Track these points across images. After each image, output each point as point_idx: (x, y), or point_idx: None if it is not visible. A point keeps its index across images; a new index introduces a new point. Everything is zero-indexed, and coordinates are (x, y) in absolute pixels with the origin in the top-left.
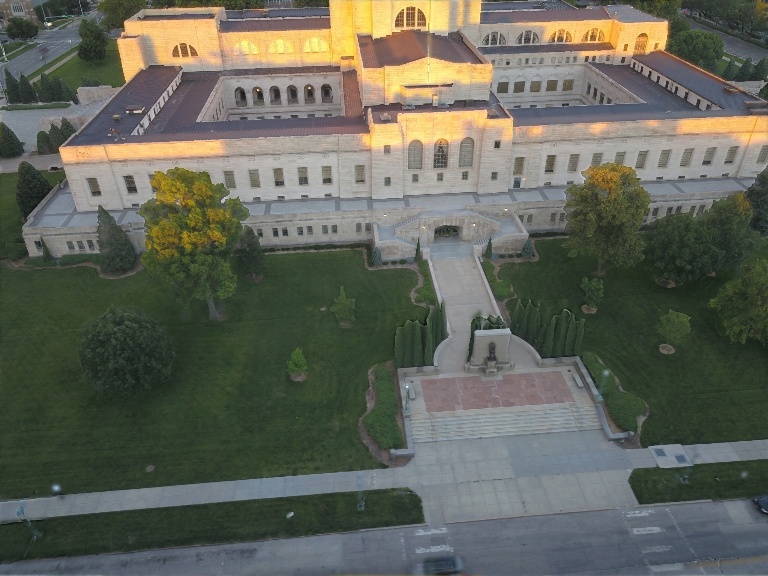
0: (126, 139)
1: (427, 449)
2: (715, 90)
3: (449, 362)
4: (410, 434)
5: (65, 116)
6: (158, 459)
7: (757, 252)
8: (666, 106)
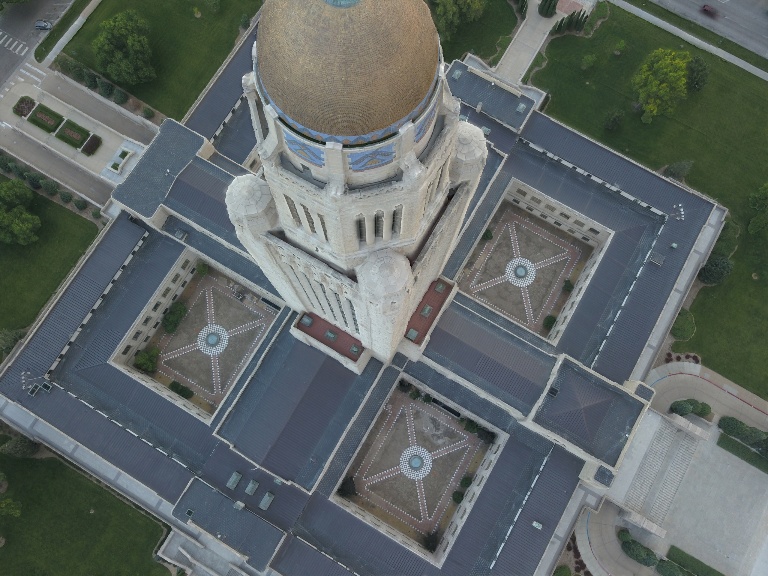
0: (673, 205)
1: None
2: None
3: None
4: None
5: (688, 426)
6: (679, 47)
7: None
8: None
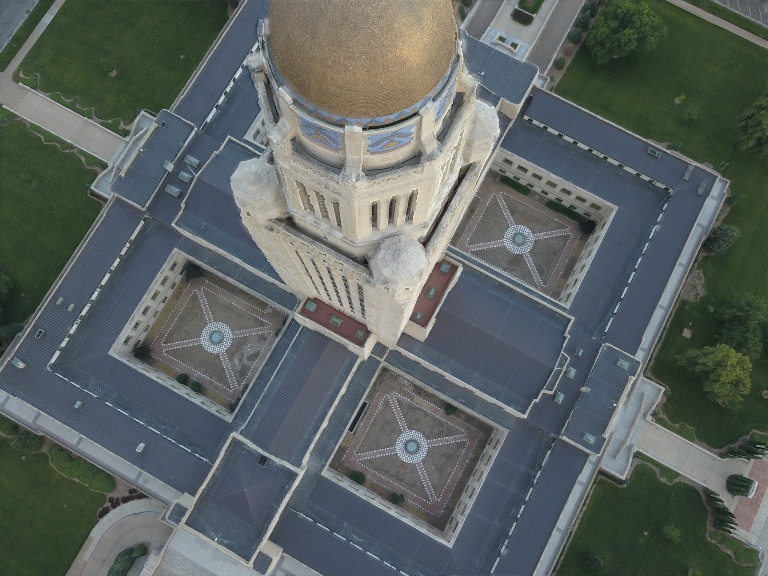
0: None
1: (762, 543)
2: (643, 157)
3: (724, 500)
4: (755, 547)
5: None
6: None
7: (729, 269)
8: (625, 196)
